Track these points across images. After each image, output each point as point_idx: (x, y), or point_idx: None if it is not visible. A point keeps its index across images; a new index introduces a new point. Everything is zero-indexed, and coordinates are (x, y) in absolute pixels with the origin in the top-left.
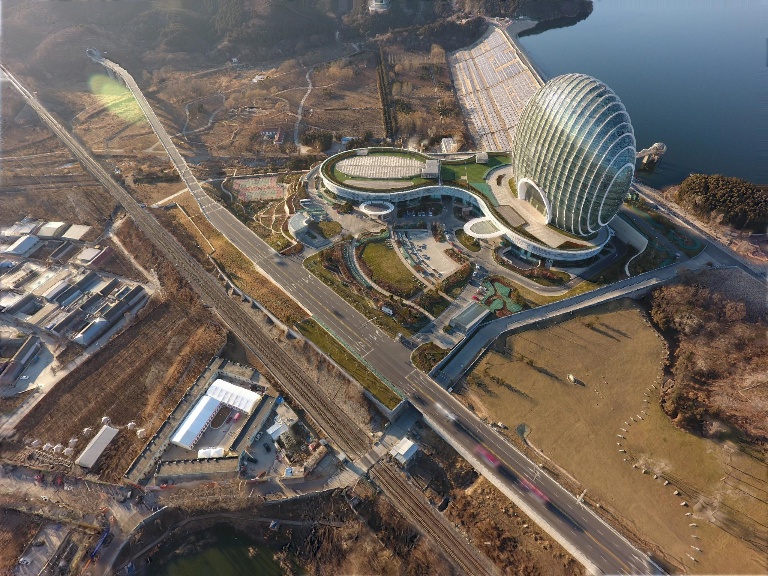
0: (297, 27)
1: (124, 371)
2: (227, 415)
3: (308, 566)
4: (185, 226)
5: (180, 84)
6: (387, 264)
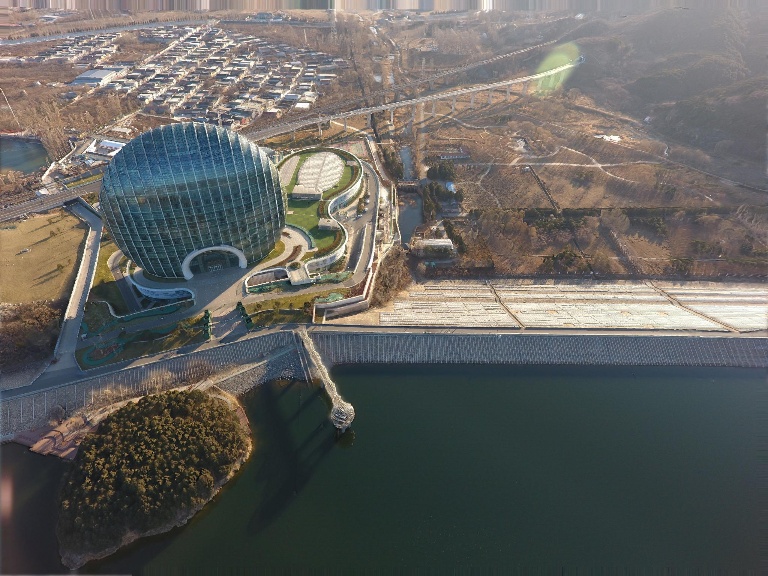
0: (765, 128)
1: None
2: None
3: None
4: (299, 131)
5: None
6: None
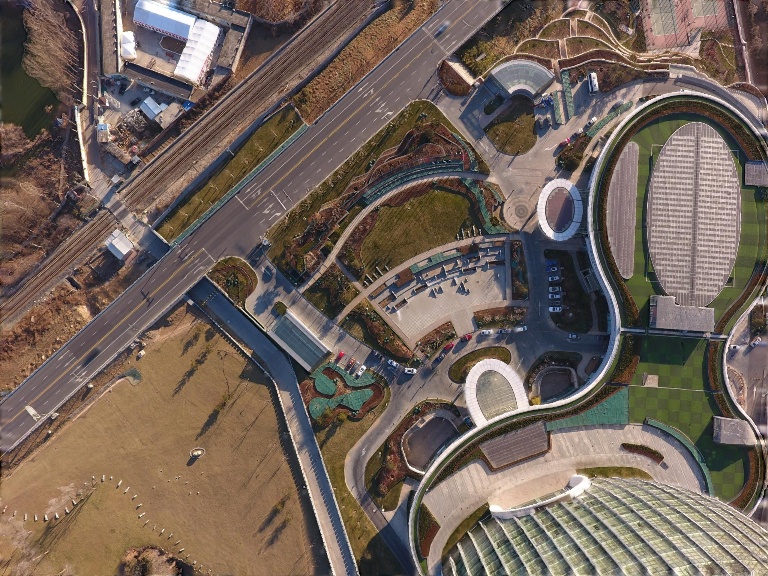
0: None
1: None
2: (176, 51)
3: (34, 159)
4: None
5: None
6: (414, 229)
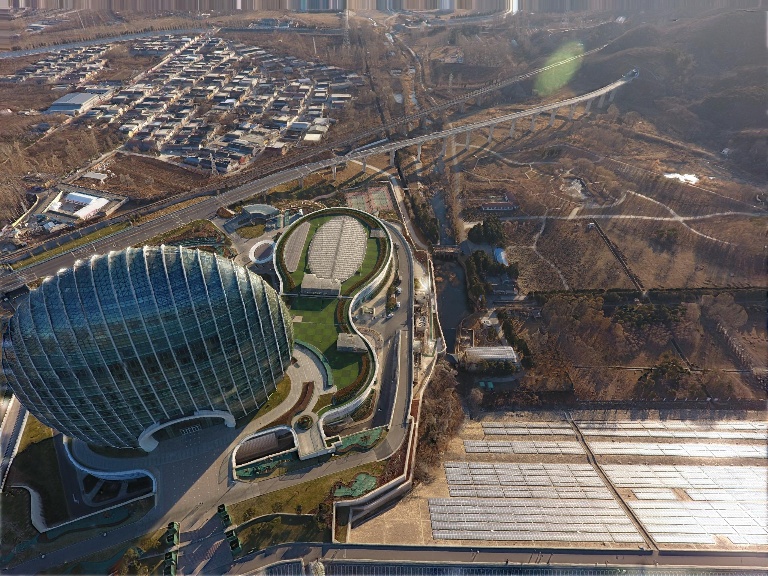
0: None
1: (150, 175)
2: None
3: None
4: None
5: (616, 132)
6: None
